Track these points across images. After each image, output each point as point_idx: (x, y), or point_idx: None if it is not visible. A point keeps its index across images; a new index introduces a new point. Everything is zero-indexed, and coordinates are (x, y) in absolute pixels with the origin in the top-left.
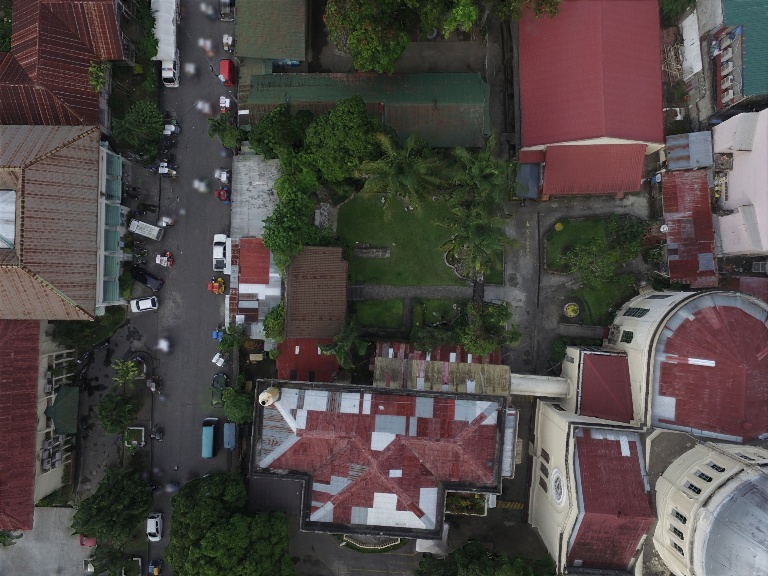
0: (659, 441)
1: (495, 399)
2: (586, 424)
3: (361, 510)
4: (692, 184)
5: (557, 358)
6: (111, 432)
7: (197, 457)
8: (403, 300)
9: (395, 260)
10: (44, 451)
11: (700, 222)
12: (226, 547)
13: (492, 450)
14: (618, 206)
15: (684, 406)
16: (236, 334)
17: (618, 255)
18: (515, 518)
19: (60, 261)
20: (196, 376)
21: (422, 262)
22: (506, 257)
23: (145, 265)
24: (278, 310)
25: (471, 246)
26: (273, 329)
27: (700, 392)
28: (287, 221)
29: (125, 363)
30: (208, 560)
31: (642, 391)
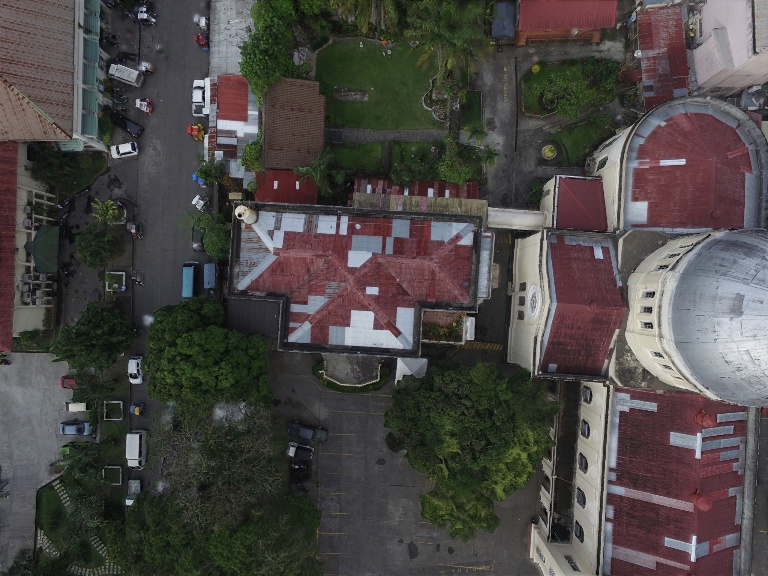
0: (631, 239)
1: (471, 221)
2: (559, 229)
3: (338, 329)
4: (667, 21)
5: (535, 200)
6: (91, 266)
7: (178, 302)
8: (382, 143)
9: (373, 104)
10: (24, 284)
11: (675, 58)
12: (202, 348)
13: (468, 271)
14: (595, 51)
15: (656, 208)
16: (214, 164)
17: (594, 93)
18: (494, 359)
19: (36, 76)
20: (176, 222)
21: (400, 106)
22: (484, 102)
23: (125, 112)
24: (256, 142)
25: (444, 53)
26: (250, 154)
27: (671, 191)
28: (263, 44)
29: (105, 203)
30: (184, 358)
31: (615, 201)
